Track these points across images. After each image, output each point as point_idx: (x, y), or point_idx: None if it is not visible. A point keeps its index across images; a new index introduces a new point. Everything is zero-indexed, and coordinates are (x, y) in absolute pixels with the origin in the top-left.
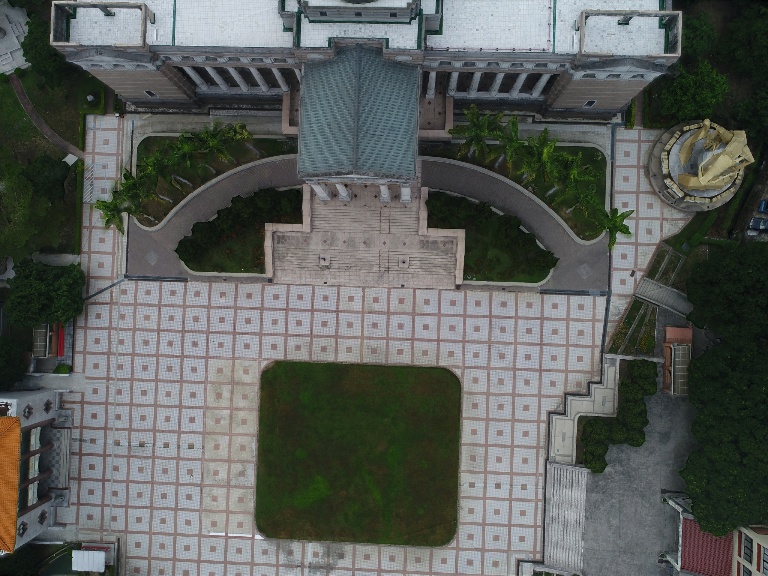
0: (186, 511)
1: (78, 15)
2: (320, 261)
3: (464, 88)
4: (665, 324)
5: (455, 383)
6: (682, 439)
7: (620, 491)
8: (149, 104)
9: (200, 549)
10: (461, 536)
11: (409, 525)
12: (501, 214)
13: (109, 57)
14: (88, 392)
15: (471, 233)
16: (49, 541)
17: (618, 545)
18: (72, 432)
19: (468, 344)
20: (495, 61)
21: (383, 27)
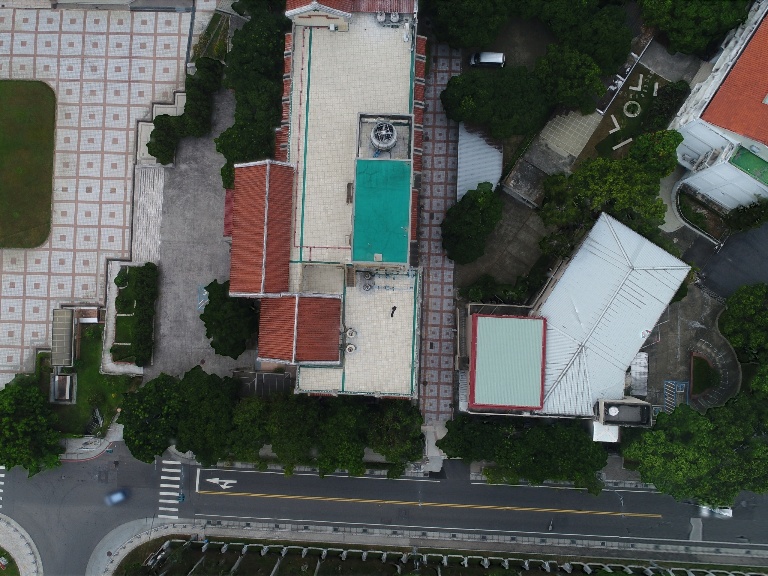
0: None
1: None
2: None
3: None
4: None
5: (50, 95)
6: None
7: (195, 186)
8: None
9: None
10: (54, 237)
11: (5, 228)
12: None
13: None
14: None
15: None
16: None
17: (192, 236)
18: None
19: (63, 58)
20: None
21: None
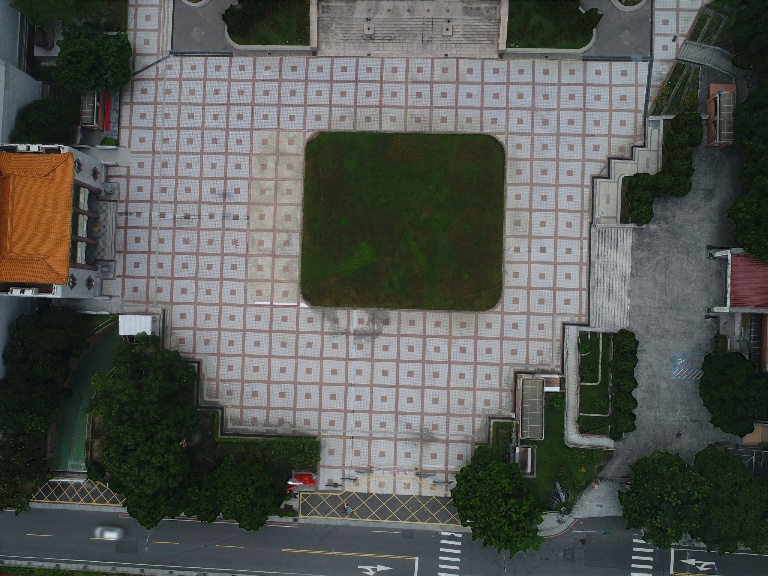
0: (231, 281)
1: None
2: (364, 30)
3: None
4: (708, 83)
5: (499, 149)
6: (727, 195)
7: (665, 248)
8: None
9: (245, 318)
10: (506, 300)
11: (454, 290)
12: None
13: None
14: (134, 166)
15: None
16: (95, 311)
17: (664, 301)
18: (118, 206)
19: (511, 111)
20: None
21: None
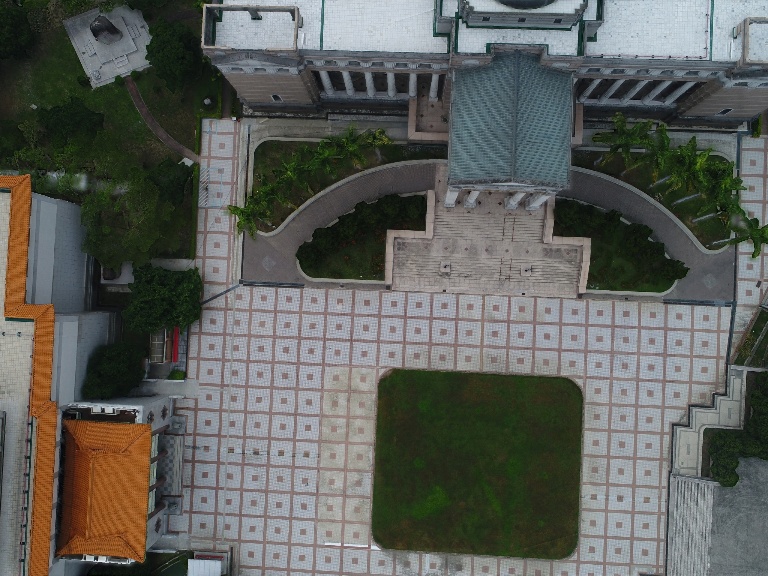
0: (301, 520)
1: (224, 18)
2: (441, 268)
3: (594, 95)
4: None
5: (577, 393)
6: None
7: (748, 505)
8: (268, 108)
9: (315, 559)
10: (582, 549)
11: (529, 537)
12: (626, 223)
13: (257, 61)
14: (202, 399)
15: (596, 241)
16: (162, 549)
17: (745, 560)
18: (185, 439)
19: (590, 354)
20: (648, 68)
21: (542, 33)
